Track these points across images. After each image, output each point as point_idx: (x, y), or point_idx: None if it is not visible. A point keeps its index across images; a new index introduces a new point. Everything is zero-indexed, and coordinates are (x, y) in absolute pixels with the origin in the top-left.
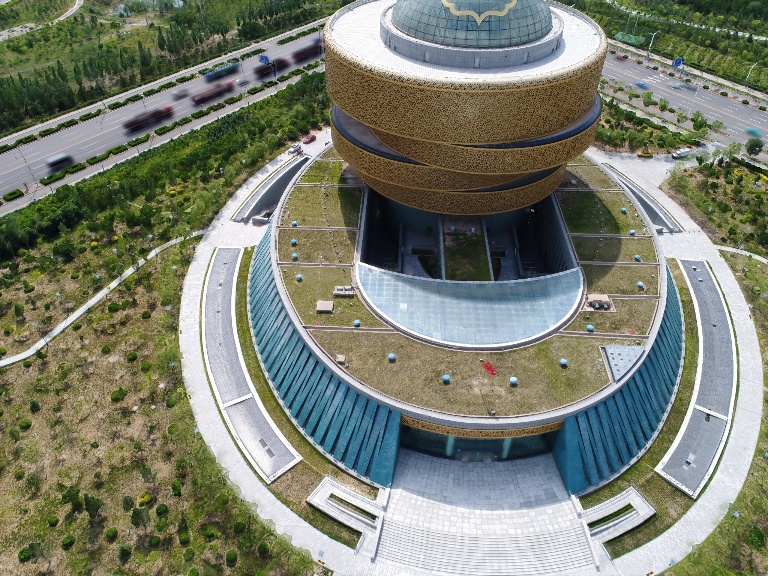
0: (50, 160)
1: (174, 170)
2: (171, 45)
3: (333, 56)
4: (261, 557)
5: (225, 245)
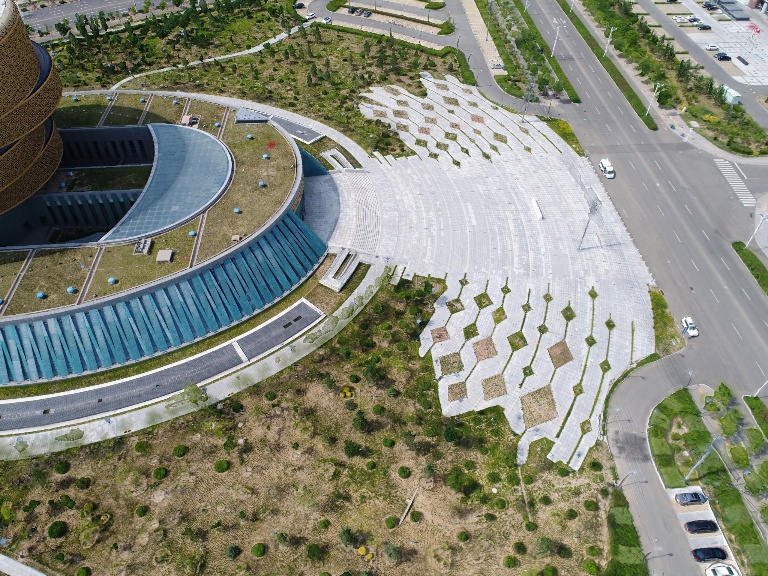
0: None
1: None
2: None
3: None
4: (383, 311)
5: None
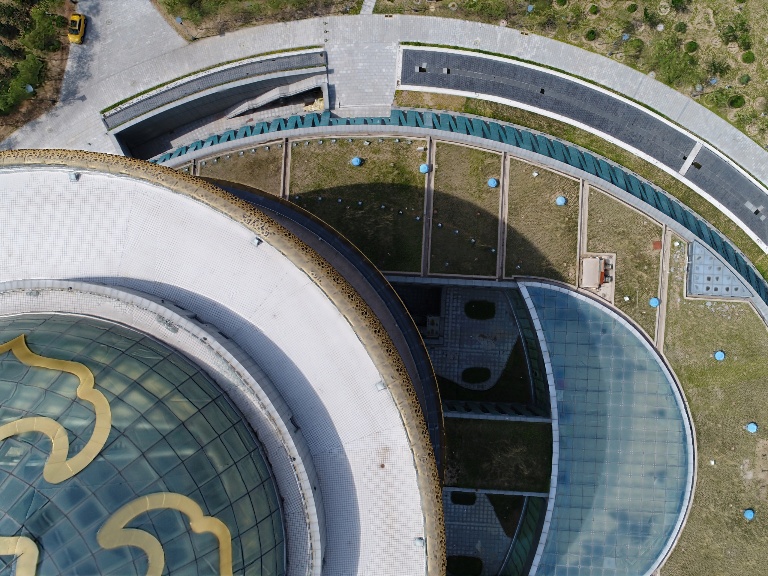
0: None
1: None
2: None
3: None
4: None
5: None
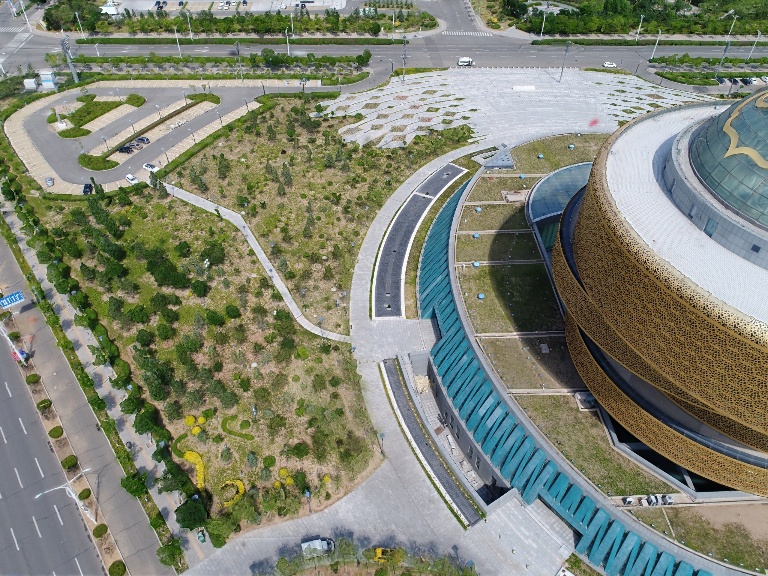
0: None
1: None
2: None
3: None
4: None
5: None
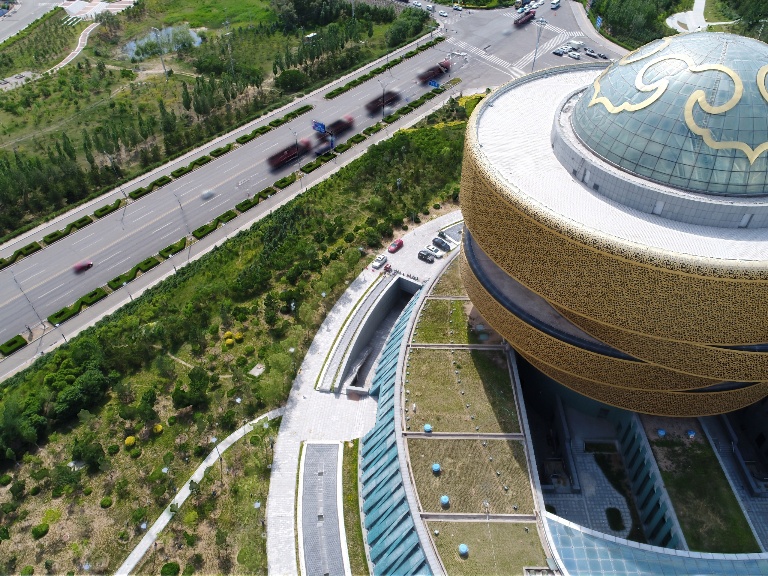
0: (60, 283)
1: (226, 299)
2: (199, 105)
3: (501, 200)
4: None
5: (315, 437)
